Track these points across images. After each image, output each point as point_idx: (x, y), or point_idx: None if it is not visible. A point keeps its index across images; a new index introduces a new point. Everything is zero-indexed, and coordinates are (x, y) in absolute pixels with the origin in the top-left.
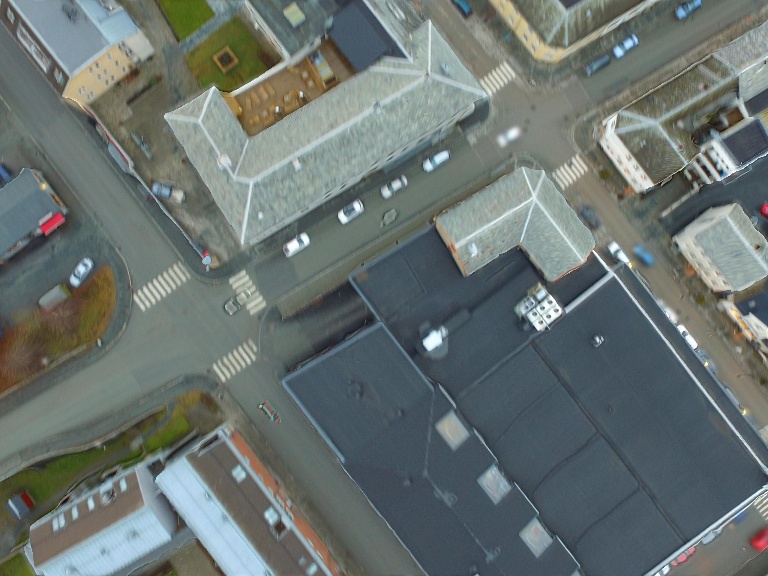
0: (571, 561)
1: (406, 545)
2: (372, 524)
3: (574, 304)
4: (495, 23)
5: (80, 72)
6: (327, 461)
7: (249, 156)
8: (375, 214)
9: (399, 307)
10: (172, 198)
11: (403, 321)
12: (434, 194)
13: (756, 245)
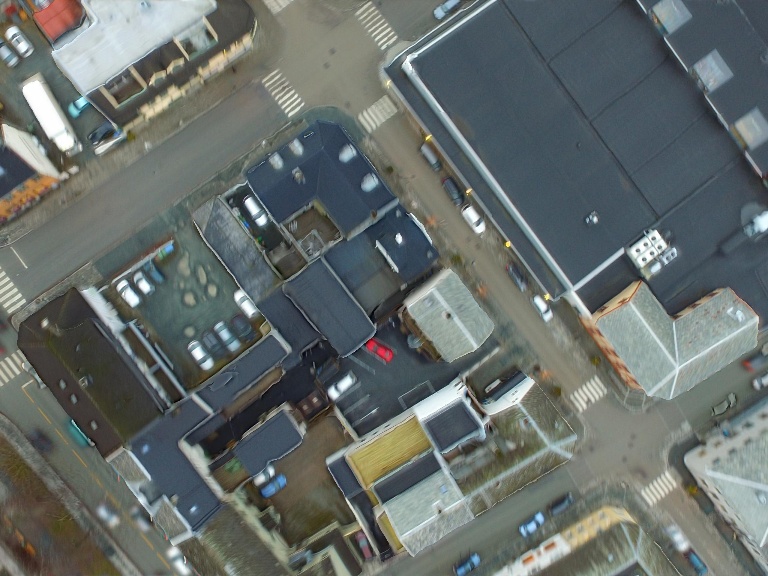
0: None
1: None
2: None
3: (616, 257)
4: (662, 545)
5: None
6: None
7: None
8: None
9: None
10: None
11: None
12: (725, 371)
13: None
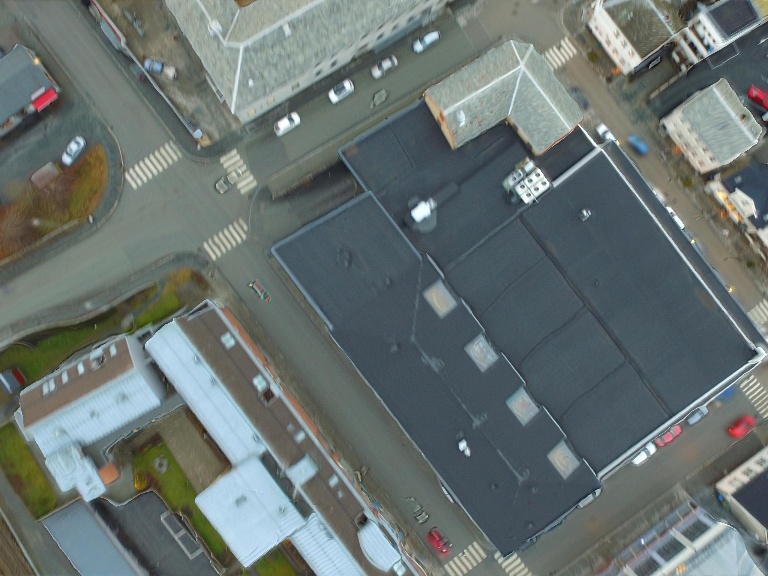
0: (557, 431)
1: (394, 413)
2: (361, 403)
3: (562, 178)
4: None
5: None
6: (316, 340)
7: (240, 24)
8: (365, 95)
9: (388, 182)
10: (164, 74)
11: (392, 195)
12: (424, 75)
13: (742, 114)
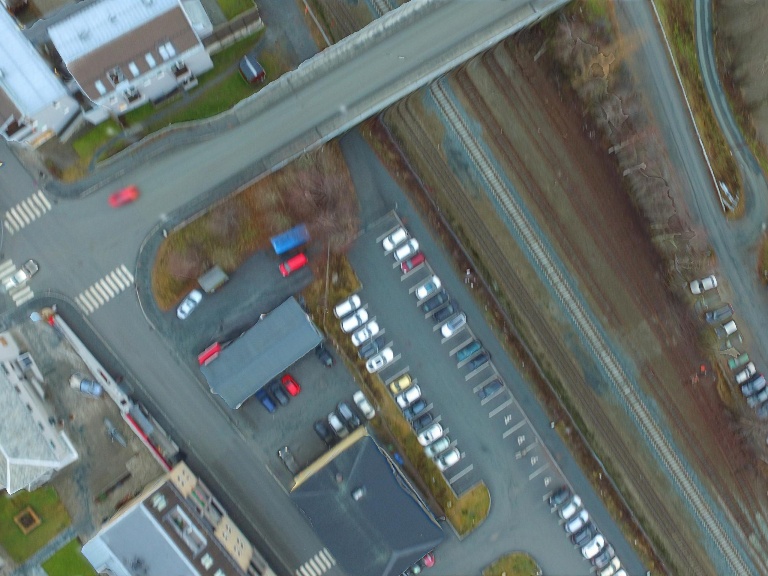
0: None
1: None
2: None
3: None
4: None
5: (132, 507)
6: None
7: None
8: None
9: None
10: None
11: None
12: None
13: None
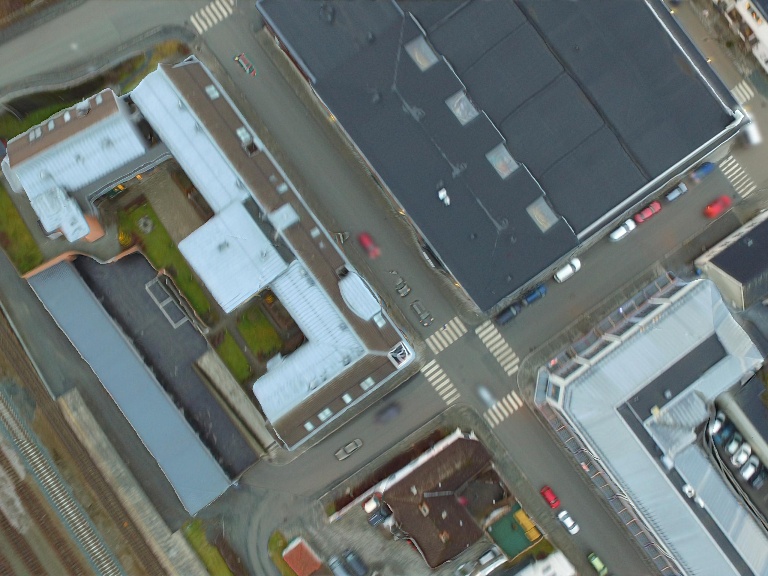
0: (537, 188)
1: (375, 168)
2: (344, 177)
3: None
4: None
5: None
6: (301, 114)
7: None
8: None
9: None
10: None
11: None
12: None
13: None
